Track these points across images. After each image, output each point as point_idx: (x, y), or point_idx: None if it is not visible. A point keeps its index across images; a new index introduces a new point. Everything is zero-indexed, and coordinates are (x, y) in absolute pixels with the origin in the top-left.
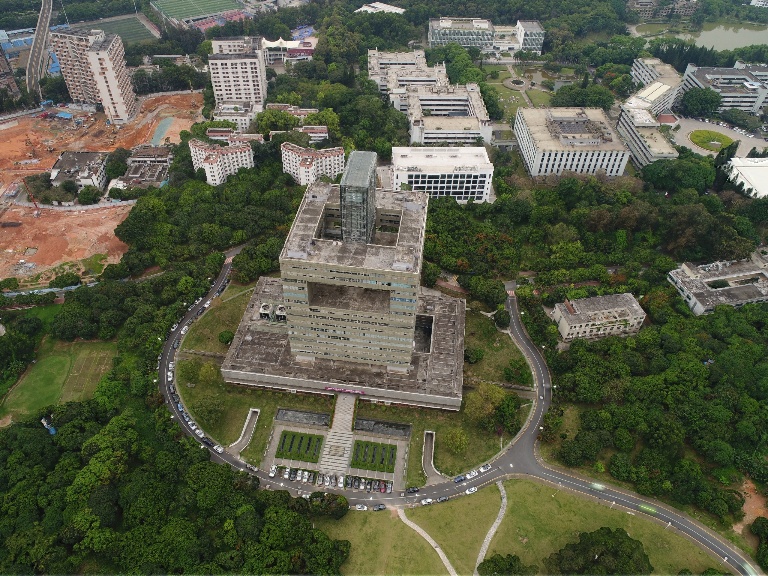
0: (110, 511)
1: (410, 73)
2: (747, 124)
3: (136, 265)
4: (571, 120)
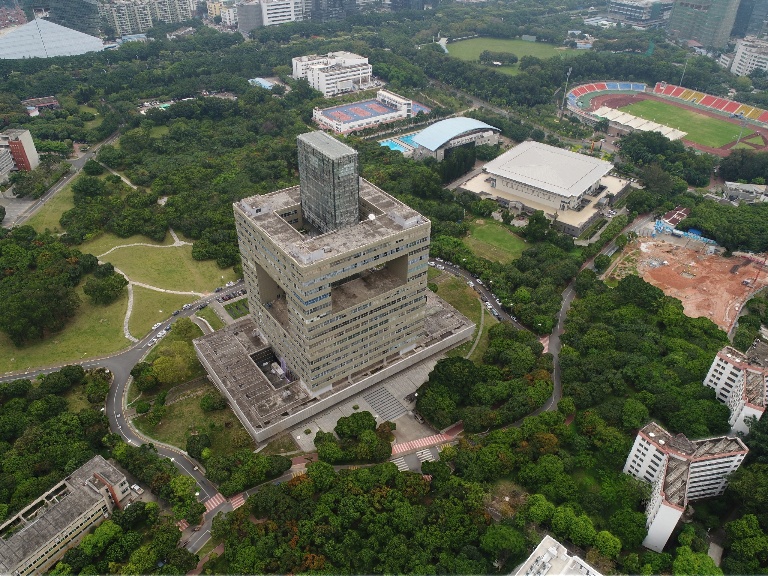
0: None
1: None
2: None
3: None
4: None
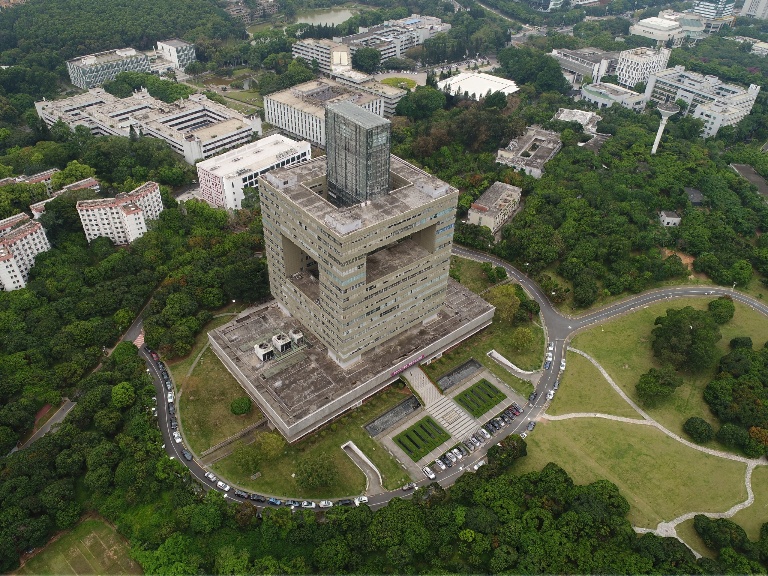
0: None
1: (114, 108)
2: (408, 65)
3: (25, 418)
4: (318, 91)
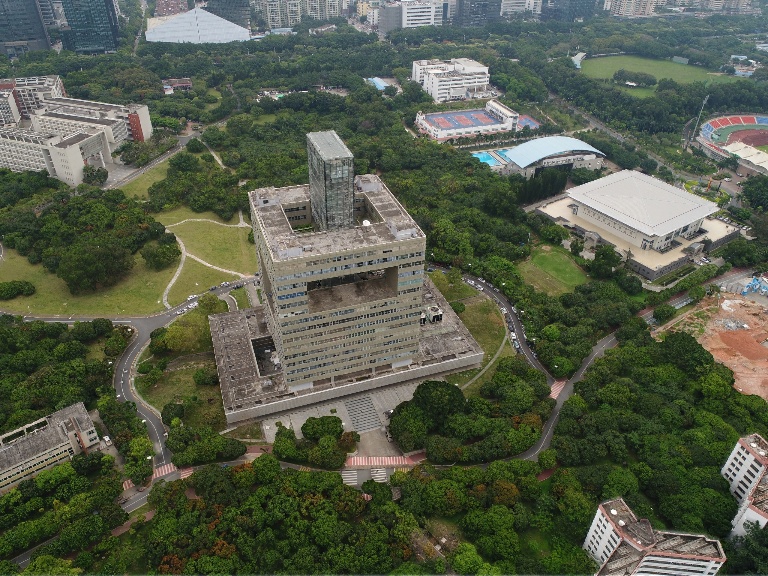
0: (416, 219)
1: None
2: None
3: None
4: None
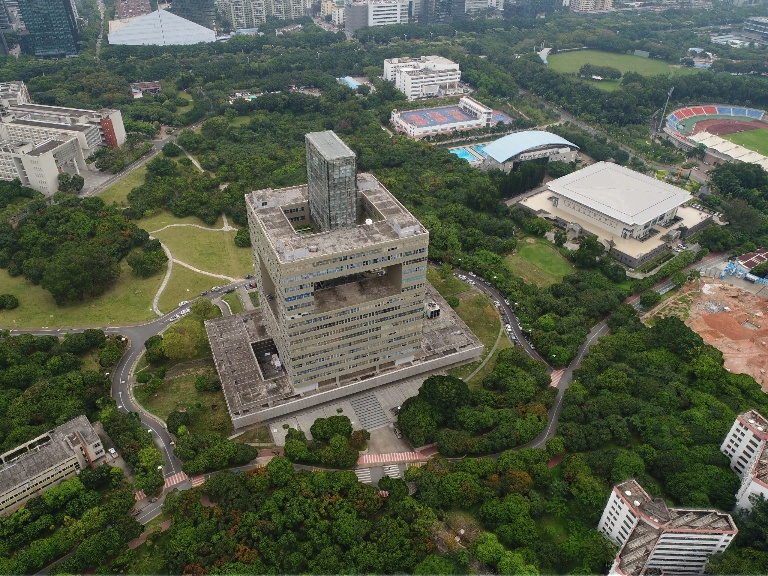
0: None
1: None
2: None
3: None
4: None
